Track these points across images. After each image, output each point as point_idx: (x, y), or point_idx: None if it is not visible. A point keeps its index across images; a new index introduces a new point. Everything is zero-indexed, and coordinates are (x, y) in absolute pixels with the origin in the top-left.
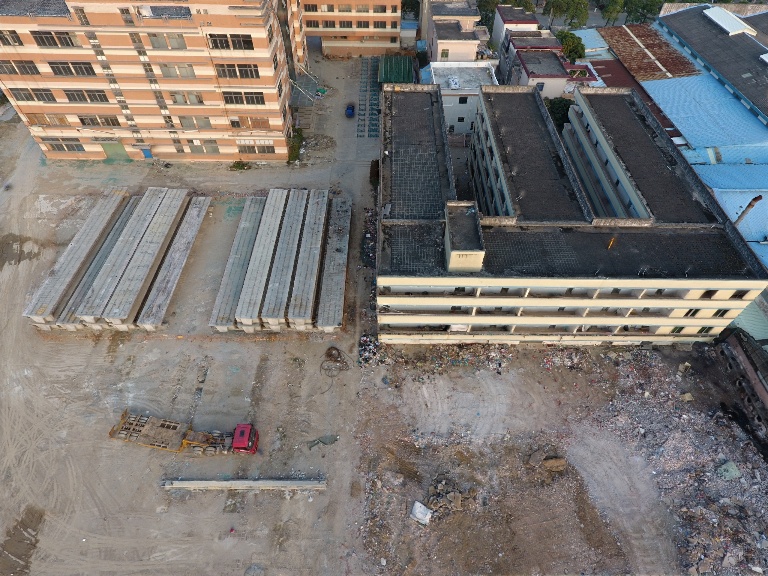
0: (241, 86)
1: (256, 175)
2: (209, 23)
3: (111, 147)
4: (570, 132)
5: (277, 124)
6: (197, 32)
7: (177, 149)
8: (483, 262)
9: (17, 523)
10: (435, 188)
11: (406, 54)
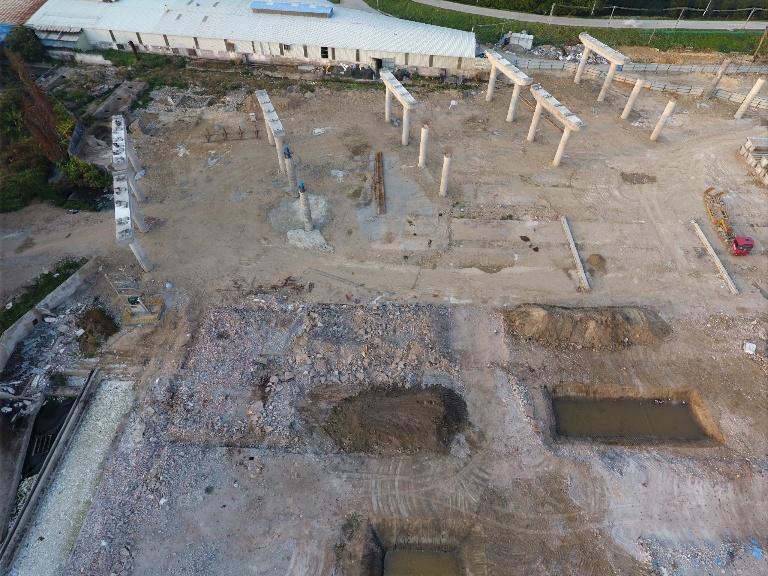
0: None
1: None
2: None
3: None
4: None
5: None
6: None
7: None
8: None
9: (647, 175)
10: None
11: None
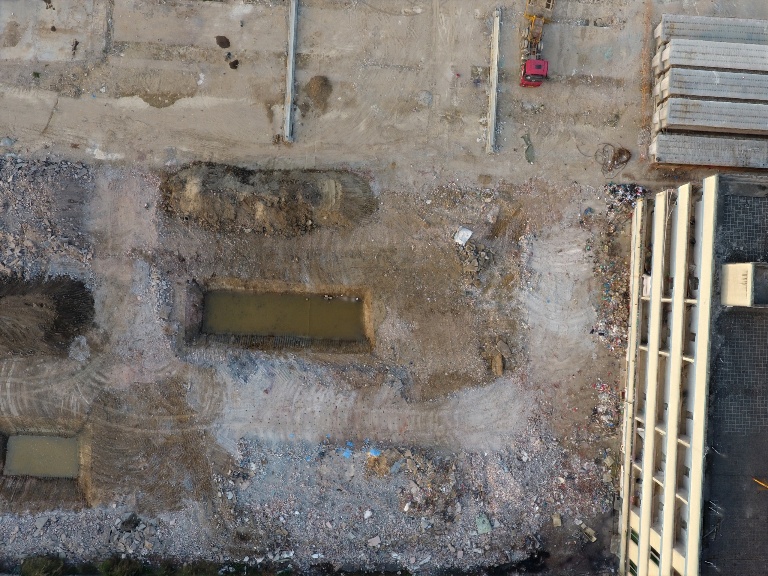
0: None
1: None
2: None
3: None
4: None
5: None
6: None
7: None
8: (737, 311)
9: None
10: None
11: None
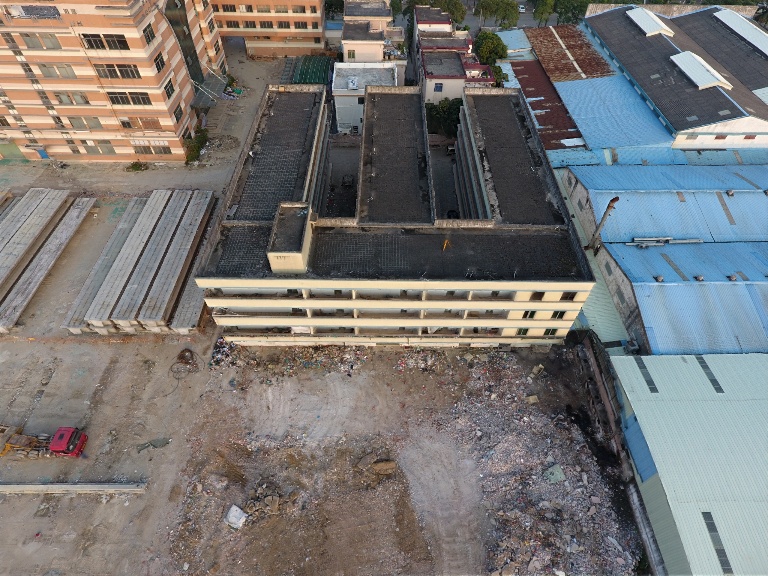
0: (124, 86)
1: (151, 176)
2: (79, 23)
3: (6, 147)
4: (461, 133)
5: (168, 125)
6: (69, 32)
7: (72, 150)
8: (312, 264)
9: None
10: (288, 189)
11: (331, 55)
